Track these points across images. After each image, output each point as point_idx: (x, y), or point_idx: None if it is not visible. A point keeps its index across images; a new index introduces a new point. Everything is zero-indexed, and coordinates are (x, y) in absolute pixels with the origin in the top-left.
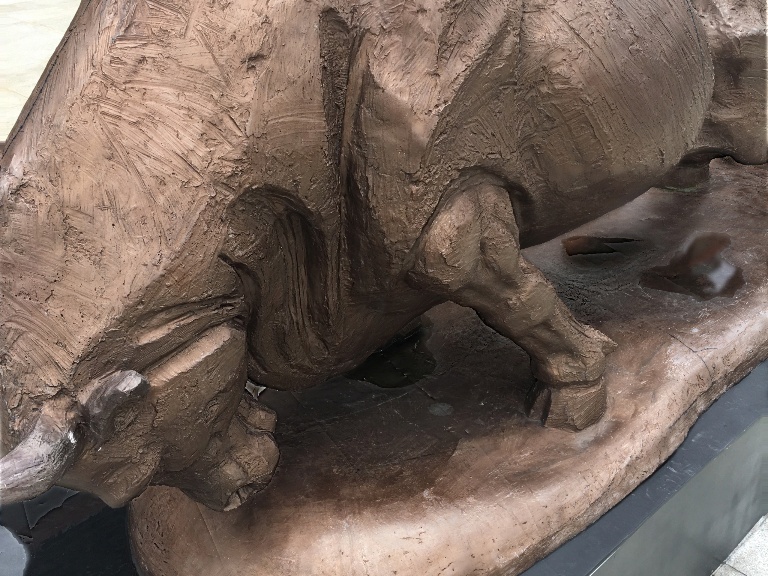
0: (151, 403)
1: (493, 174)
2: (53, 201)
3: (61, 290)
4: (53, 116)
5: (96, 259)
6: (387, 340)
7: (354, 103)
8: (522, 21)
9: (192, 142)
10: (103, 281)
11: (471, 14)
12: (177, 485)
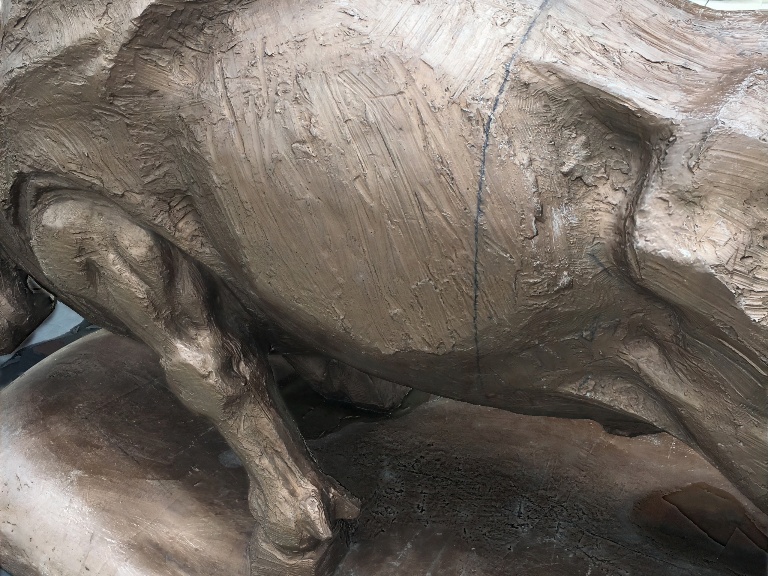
0: None
1: None
2: None
3: None
4: None
5: None
6: (329, 390)
7: None
8: (182, 57)
9: None
10: None
11: (49, 17)
12: None
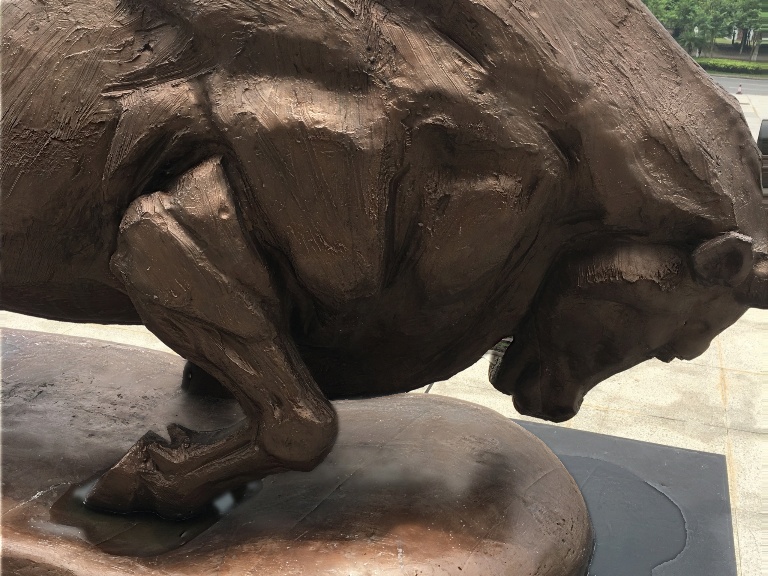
0: None
1: None
2: None
3: None
4: None
5: None
6: None
7: None
8: None
9: None
10: None
11: None
12: None
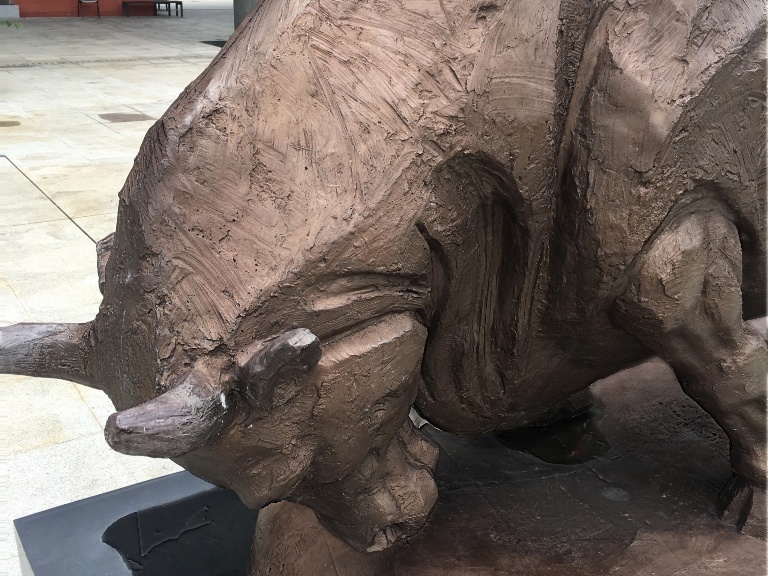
0: (315, 385)
1: (725, 202)
2: (246, 132)
3: (238, 232)
4: (260, 43)
5: (282, 203)
6: (554, 413)
7: (584, 85)
8: None
9: (405, 91)
10: (286, 228)
11: (729, 3)
12: (319, 508)
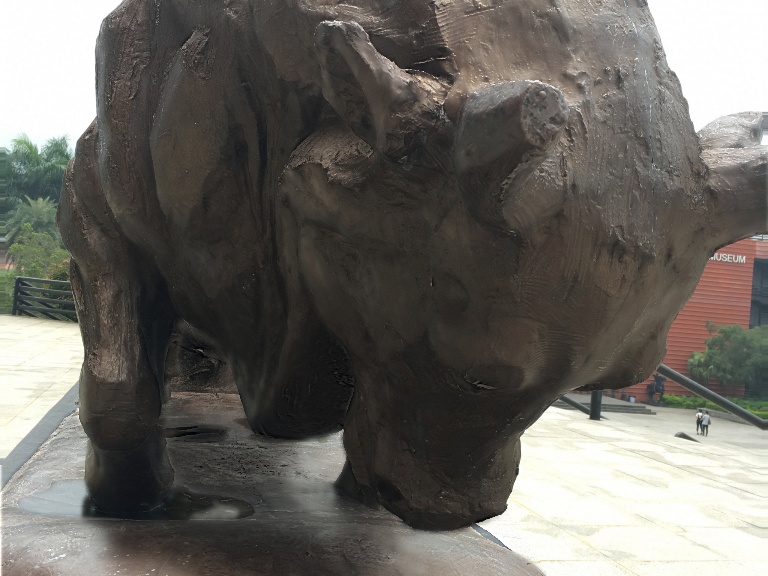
0: None
1: None
2: None
3: None
4: None
5: None
6: None
7: None
8: None
9: None
10: None
11: None
12: None
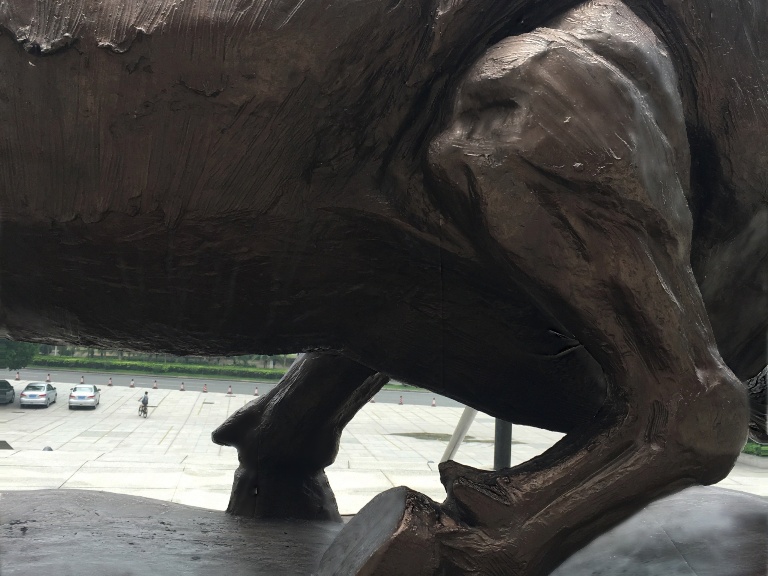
0: None
1: None
2: None
3: None
4: None
5: None
6: None
7: None
8: None
9: None
10: None
11: None
12: None
